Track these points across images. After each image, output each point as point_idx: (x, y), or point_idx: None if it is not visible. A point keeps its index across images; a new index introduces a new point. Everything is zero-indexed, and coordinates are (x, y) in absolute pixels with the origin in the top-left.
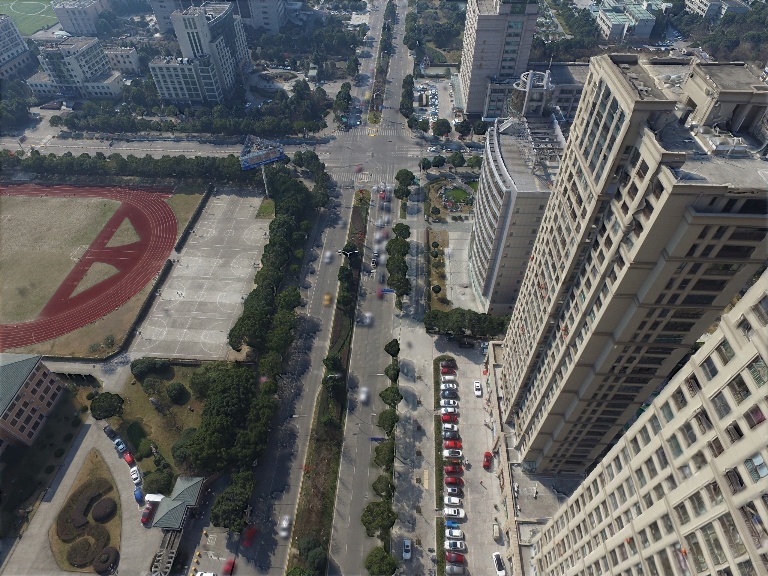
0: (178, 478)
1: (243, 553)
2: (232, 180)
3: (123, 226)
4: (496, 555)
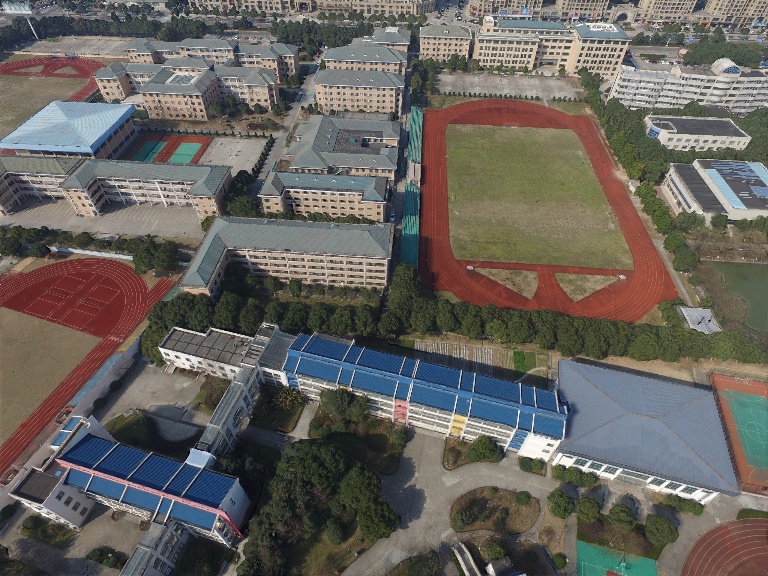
0: (204, 37)
1: (233, 35)
2: (7, 48)
3: (22, 70)
4: (250, 9)
